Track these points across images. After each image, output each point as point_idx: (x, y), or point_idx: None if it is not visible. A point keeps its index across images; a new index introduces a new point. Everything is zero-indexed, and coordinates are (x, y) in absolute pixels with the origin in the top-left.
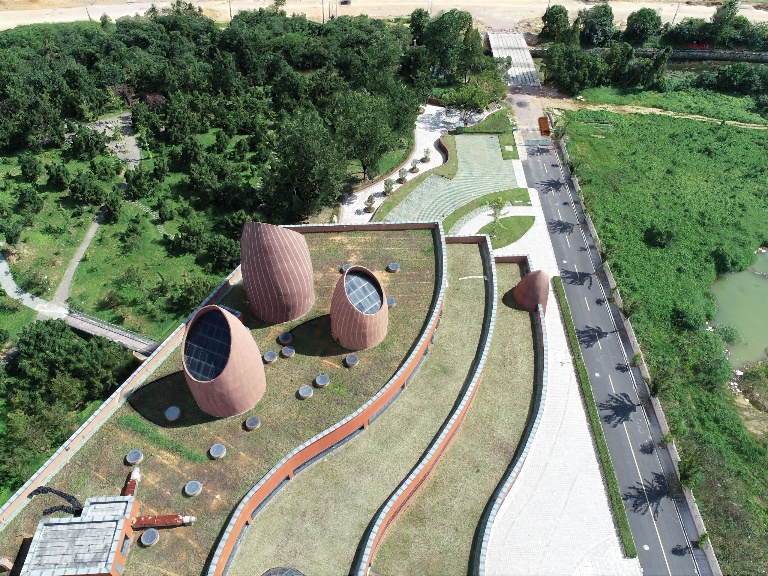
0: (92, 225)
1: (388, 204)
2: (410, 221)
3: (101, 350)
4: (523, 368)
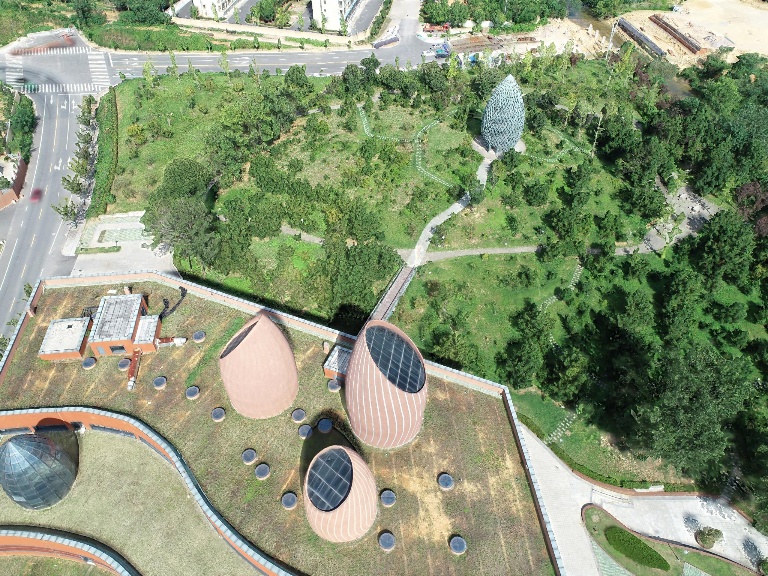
0: (532, 247)
1: (726, 569)
2: None
3: (362, 298)
4: None
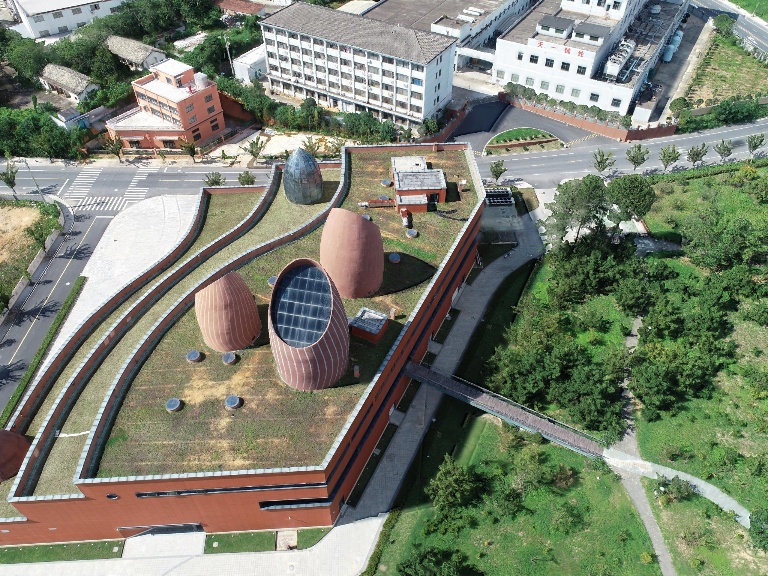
0: None
1: None
2: (121, 480)
3: None
4: (78, 365)
